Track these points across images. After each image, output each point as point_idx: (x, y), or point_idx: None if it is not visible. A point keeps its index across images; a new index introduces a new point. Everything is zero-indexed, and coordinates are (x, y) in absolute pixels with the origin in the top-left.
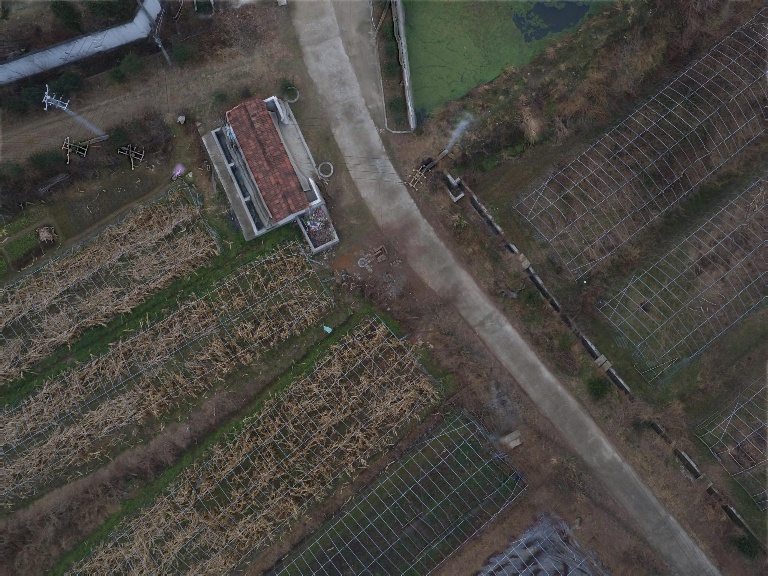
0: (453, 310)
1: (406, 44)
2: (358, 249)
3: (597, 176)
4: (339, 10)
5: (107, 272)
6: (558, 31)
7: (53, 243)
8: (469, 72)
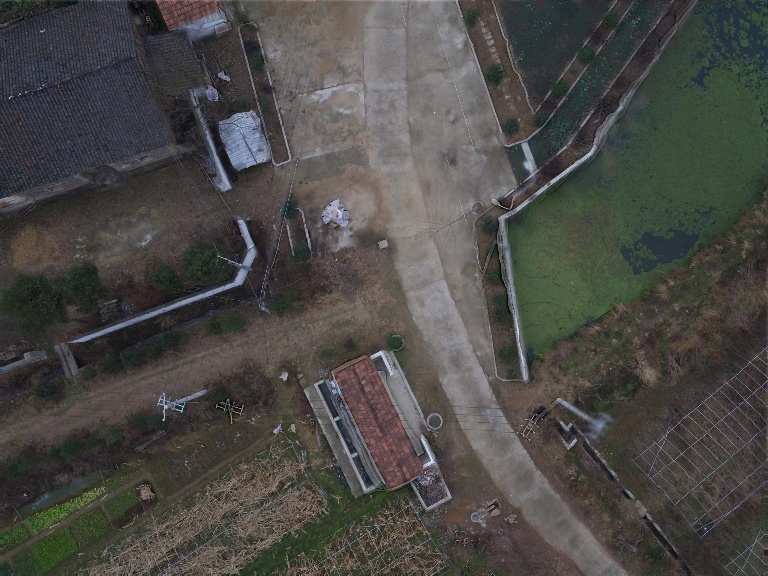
0: (570, 565)
1: (514, 286)
2: (470, 503)
3: (720, 431)
4: (443, 252)
5: (209, 534)
6: (667, 262)
7: (151, 502)
8: (577, 308)
